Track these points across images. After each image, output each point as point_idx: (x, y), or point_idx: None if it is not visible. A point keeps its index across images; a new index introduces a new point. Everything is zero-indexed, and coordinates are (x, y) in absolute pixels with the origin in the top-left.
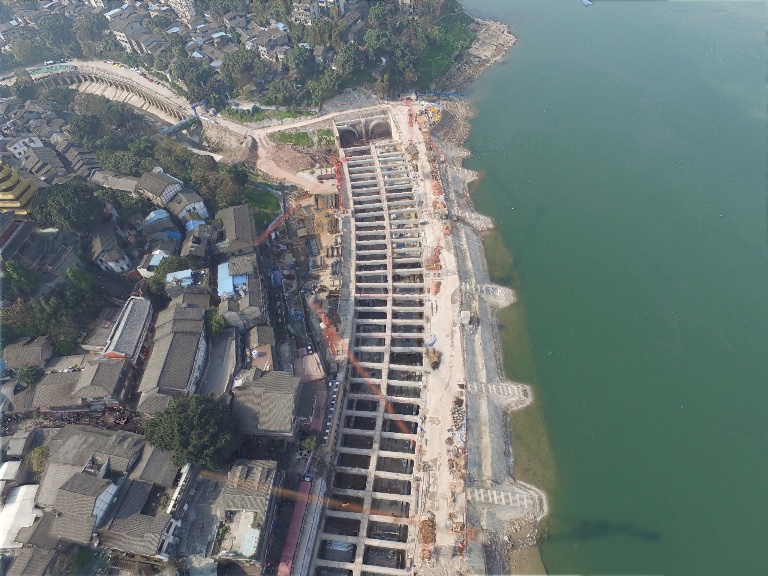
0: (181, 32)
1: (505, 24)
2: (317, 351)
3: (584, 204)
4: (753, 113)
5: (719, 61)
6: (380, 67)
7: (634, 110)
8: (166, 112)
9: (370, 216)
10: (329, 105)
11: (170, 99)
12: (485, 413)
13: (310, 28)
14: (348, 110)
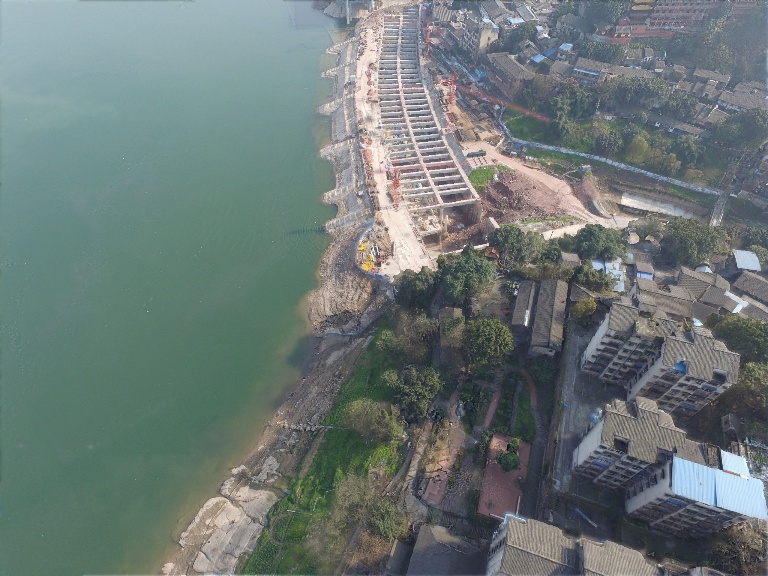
0: None
1: None
2: (436, 58)
3: (232, 169)
4: None
5: None
6: None
7: (64, 314)
8: None
9: None
10: None
11: None
12: (348, 58)
13: (610, 273)
14: None
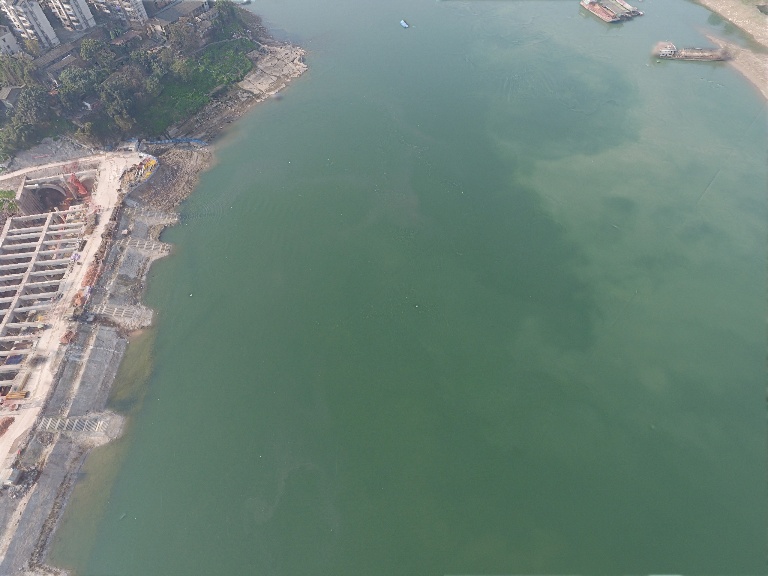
0: None
1: (304, 49)
2: None
3: (272, 290)
4: (514, 166)
5: (506, 100)
6: (84, 113)
7: (391, 161)
8: None
9: None
10: (23, 158)
11: None
12: None
13: None
14: (49, 164)
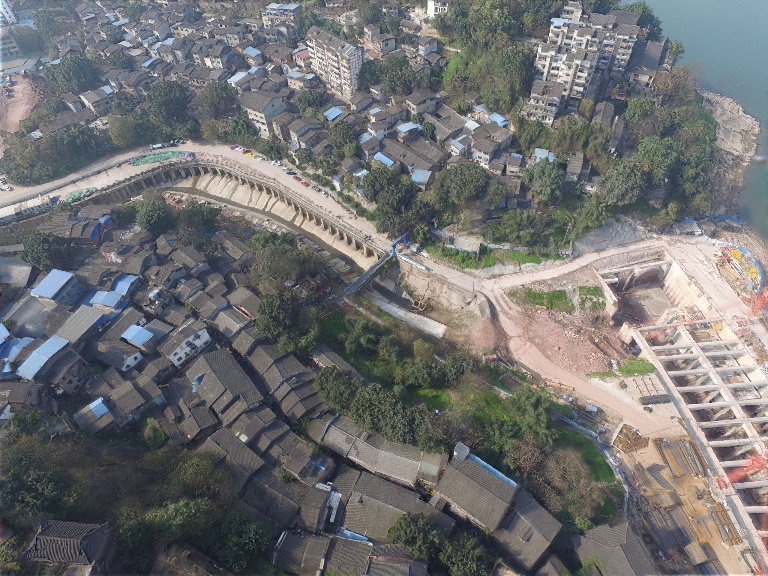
0: (346, 117)
1: (728, 97)
2: None
3: None
4: None
5: None
6: (659, 191)
7: None
8: (332, 234)
9: None
10: (583, 243)
11: (344, 220)
12: None
13: (559, 131)
14: (608, 249)
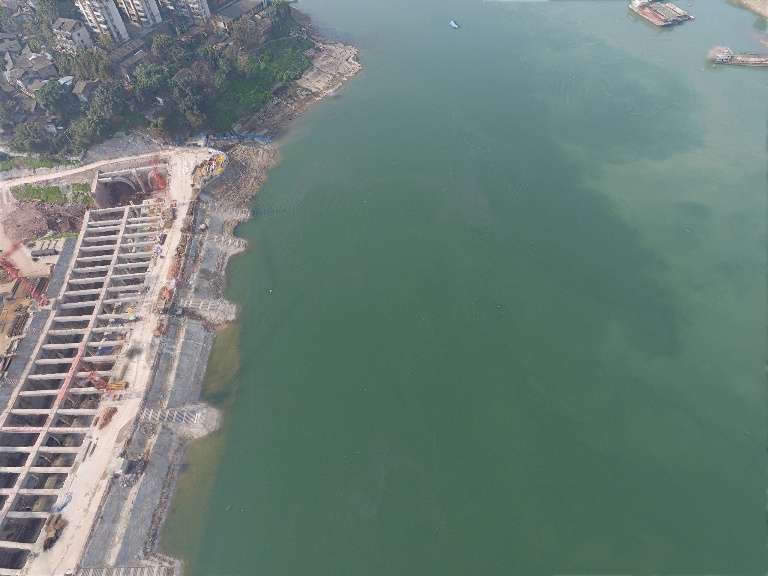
0: None
1: (356, 48)
2: None
3: (351, 287)
4: (580, 169)
5: (565, 102)
6: (156, 108)
7: (456, 161)
8: None
9: (81, 306)
10: (96, 152)
11: None
12: None
13: (72, 60)
14: (120, 158)
